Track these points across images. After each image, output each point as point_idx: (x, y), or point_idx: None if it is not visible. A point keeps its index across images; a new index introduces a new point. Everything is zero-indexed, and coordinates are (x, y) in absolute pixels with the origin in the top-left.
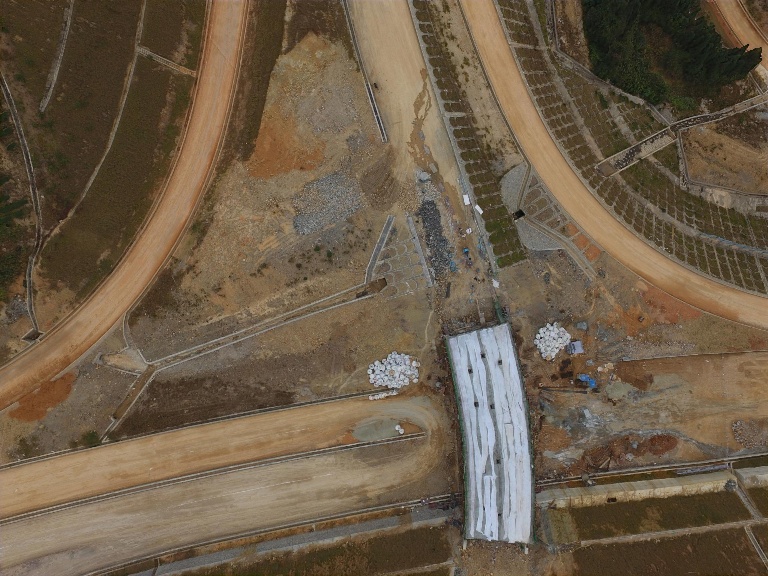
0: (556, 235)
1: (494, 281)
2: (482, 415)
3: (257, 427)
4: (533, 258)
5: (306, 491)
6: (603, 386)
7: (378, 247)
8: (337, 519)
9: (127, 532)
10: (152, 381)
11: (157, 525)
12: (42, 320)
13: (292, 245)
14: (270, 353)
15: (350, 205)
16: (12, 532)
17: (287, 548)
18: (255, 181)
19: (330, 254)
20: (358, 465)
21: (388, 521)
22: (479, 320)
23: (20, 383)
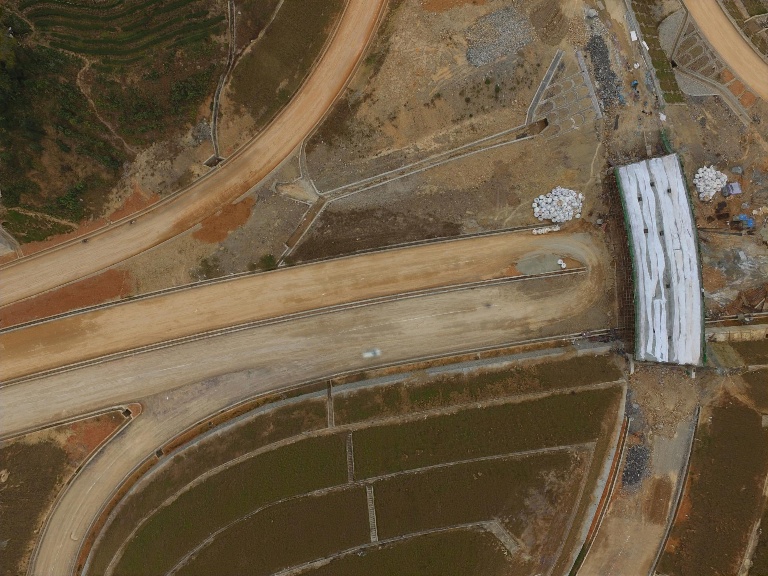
0: (710, 83)
1: (661, 114)
2: (652, 241)
3: (425, 257)
4: (689, 103)
5: (471, 321)
6: (758, 229)
7: (542, 86)
8: (501, 349)
9: (300, 355)
10: (324, 211)
11: (329, 349)
12: (224, 146)
13: (465, 76)
14: (435, 188)
15: (521, 38)
16: (192, 351)
17: (457, 370)
18: (429, 14)
19: (498, 89)
20: (521, 298)
21: (552, 350)
22: (646, 153)
23: (202, 206)
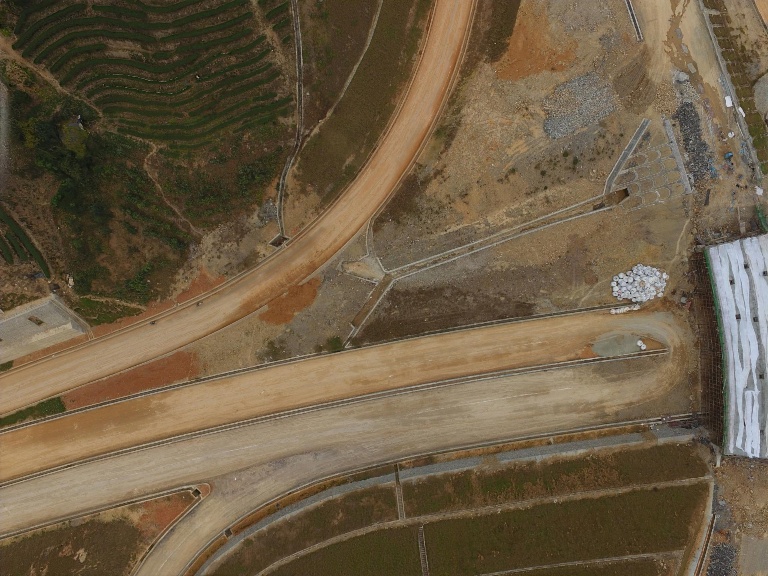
0: None
1: (758, 188)
2: (744, 328)
3: (495, 338)
4: None
5: (543, 404)
6: None
7: (624, 155)
8: (575, 433)
9: (367, 437)
10: (391, 289)
11: (396, 432)
12: (289, 225)
13: (542, 150)
14: (506, 264)
15: (604, 107)
16: (259, 432)
17: (530, 458)
18: (504, 83)
19: (576, 161)
20: (596, 380)
21: (629, 437)
22: (739, 230)
23: (268, 287)
